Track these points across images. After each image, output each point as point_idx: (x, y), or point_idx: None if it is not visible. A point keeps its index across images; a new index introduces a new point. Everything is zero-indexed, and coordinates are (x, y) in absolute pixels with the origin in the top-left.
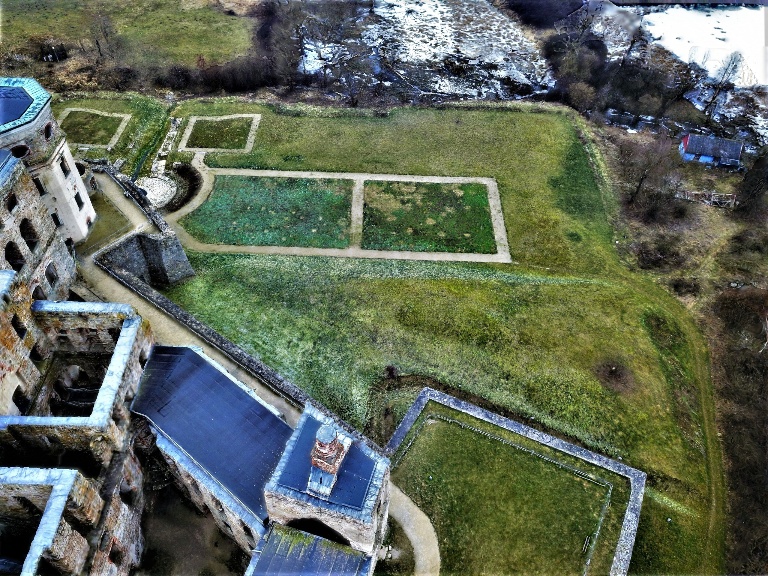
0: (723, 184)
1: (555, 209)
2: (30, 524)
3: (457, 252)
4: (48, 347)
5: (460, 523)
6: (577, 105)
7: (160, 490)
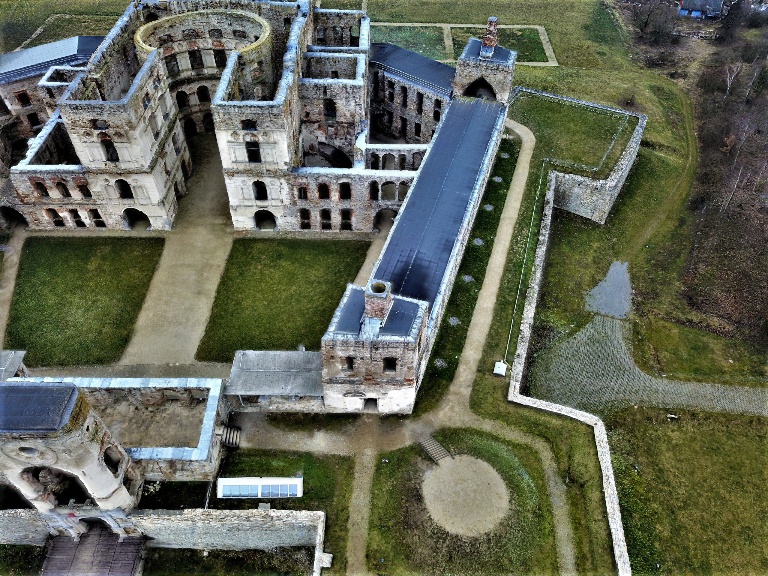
0: (708, 28)
1: (587, 40)
2: (328, 104)
3: (521, 61)
4: (314, 41)
5: (544, 128)
6: None
7: (370, 130)
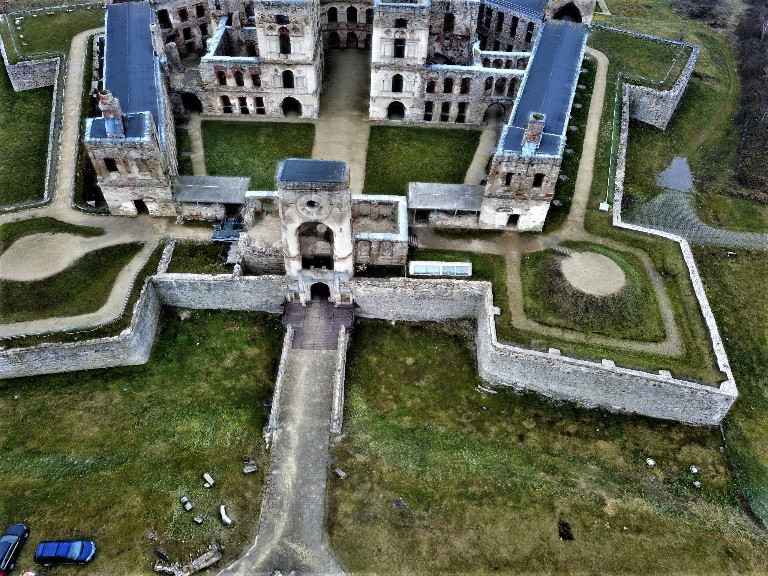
0: None
1: None
2: None
3: None
4: None
5: (615, 52)
6: None
7: None
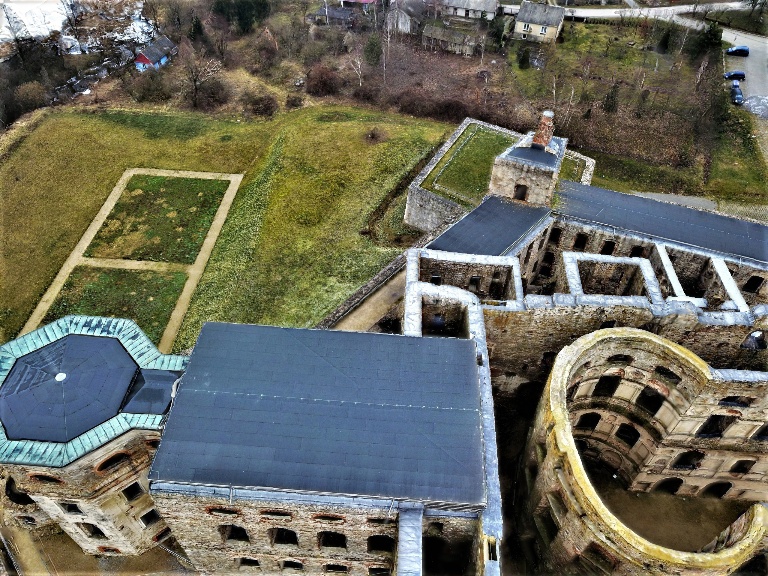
0: None
1: (188, 142)
2: None
3: (220, 203)
4: None
5: None
6: (42, 102)
7: None
